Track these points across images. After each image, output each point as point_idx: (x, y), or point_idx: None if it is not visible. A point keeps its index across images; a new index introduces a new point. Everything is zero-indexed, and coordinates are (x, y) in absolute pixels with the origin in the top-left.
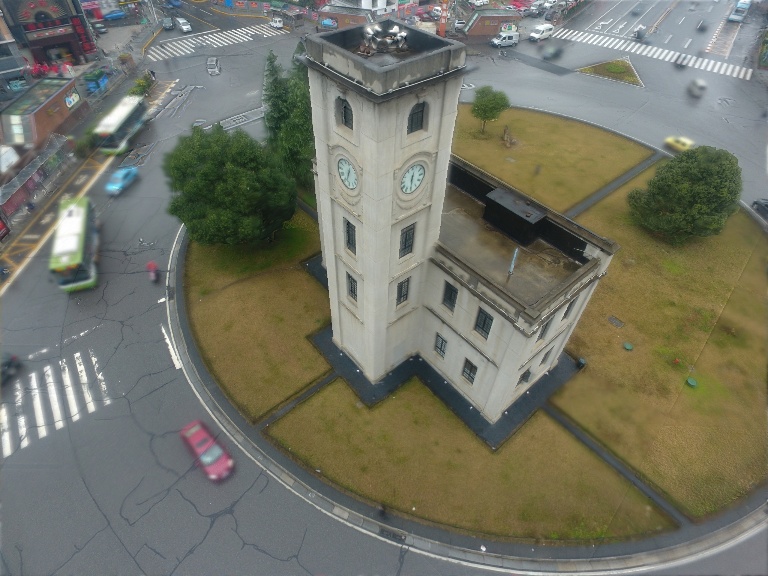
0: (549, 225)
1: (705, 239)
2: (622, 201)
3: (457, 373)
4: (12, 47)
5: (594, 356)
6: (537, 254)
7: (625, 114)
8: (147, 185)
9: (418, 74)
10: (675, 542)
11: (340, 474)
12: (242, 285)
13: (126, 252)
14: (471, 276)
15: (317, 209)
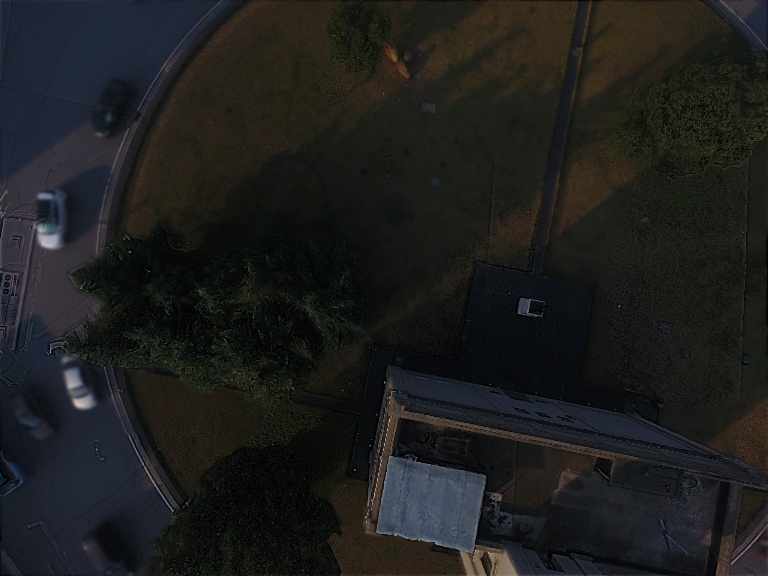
0: None
1: None
2: (594, 107)
3: None
4: None
5: (664, 386)
6: None
7: None
8: (62, 495)
9: None
10: None
11: None
12: None
13: None
14: None
15: None
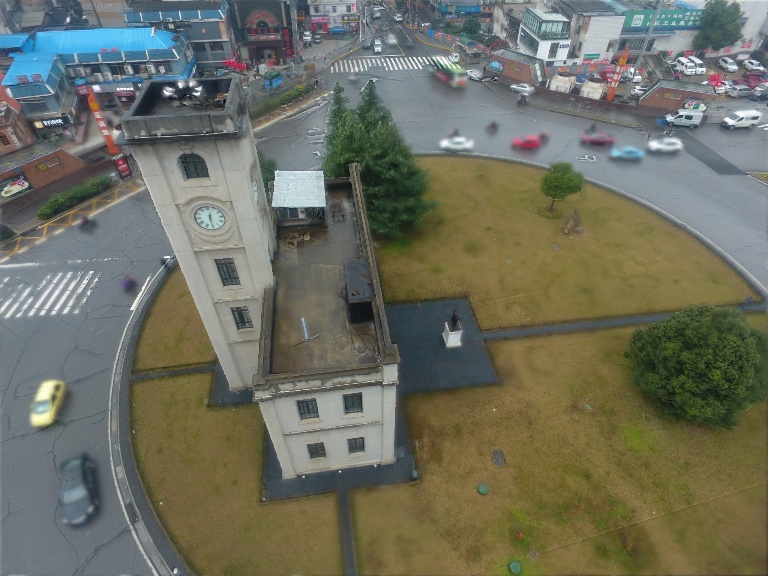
0: None
1: (720, 429)
2: None
3: None
4: (225, 45)
5: (437, 477)
6: (352, 335)
7: (767, 242)
8: None
9: (174, 129)
10: None
11: (144, 443)
12: None
13: None
14: None
15: None
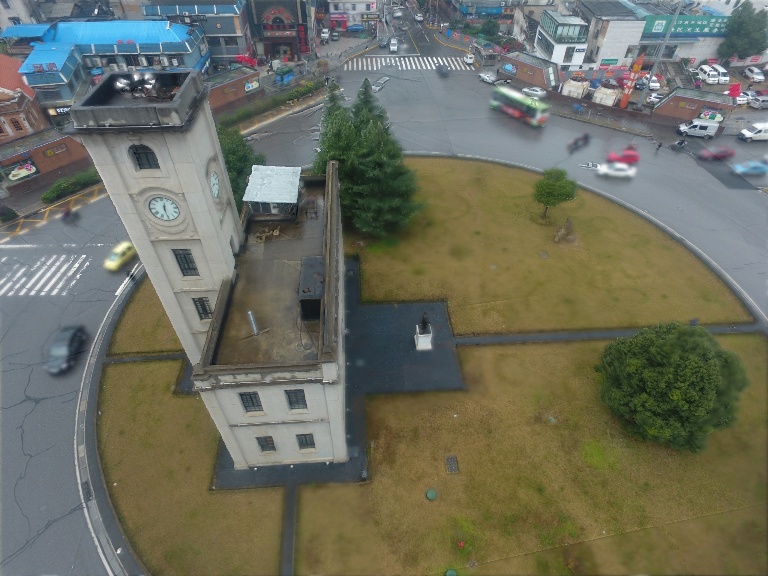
0: None
1: (687, 451)
2: None
3: None
4: (239, 39)
5: (387, 479)
6: (301, 331)
7: None
8: None
9: (122, 120)
10: None
11: (107, 425)
12: None
13: None
14: None
15: None
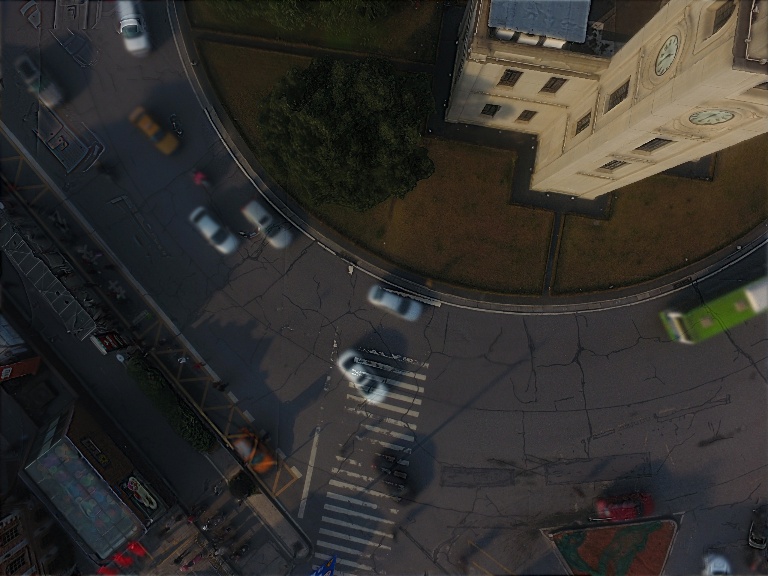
0: None
1: None
2: None
3: None
4: None
5: None
6: None
7: None
8: (143, 169)
9: None
10: None
11: (626, 277)
12: (402, 202)
13: (250, 257)
14: None
15: (459, 86)
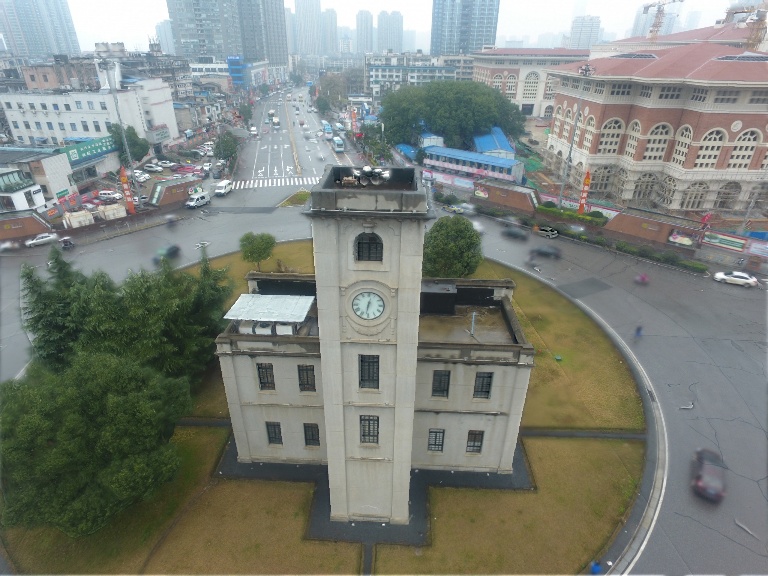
0: (459, 291)
1: (469, 276)
2: None
3: (462, 453)
4: None
5: None
6: (467, 315)
7: None
8: None
9: None
10: (655, 452)
11: None
12: (164, 552)
13: None
14: (463, 350)
15: None
